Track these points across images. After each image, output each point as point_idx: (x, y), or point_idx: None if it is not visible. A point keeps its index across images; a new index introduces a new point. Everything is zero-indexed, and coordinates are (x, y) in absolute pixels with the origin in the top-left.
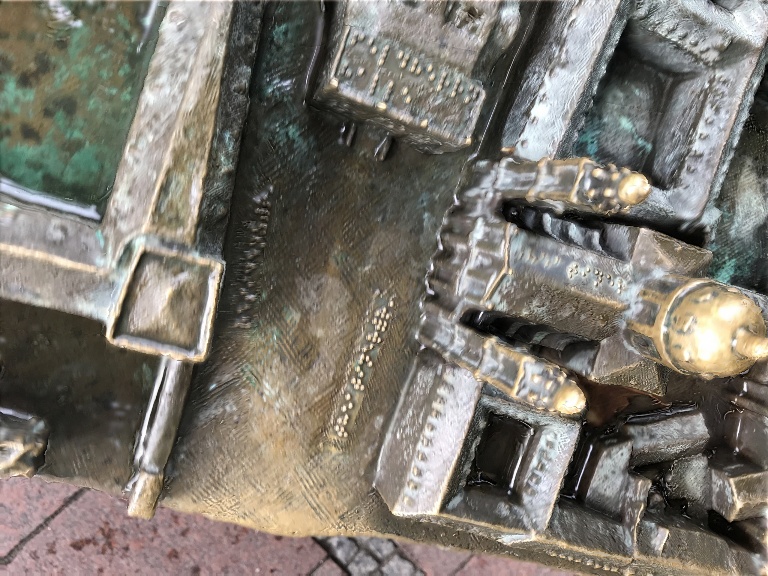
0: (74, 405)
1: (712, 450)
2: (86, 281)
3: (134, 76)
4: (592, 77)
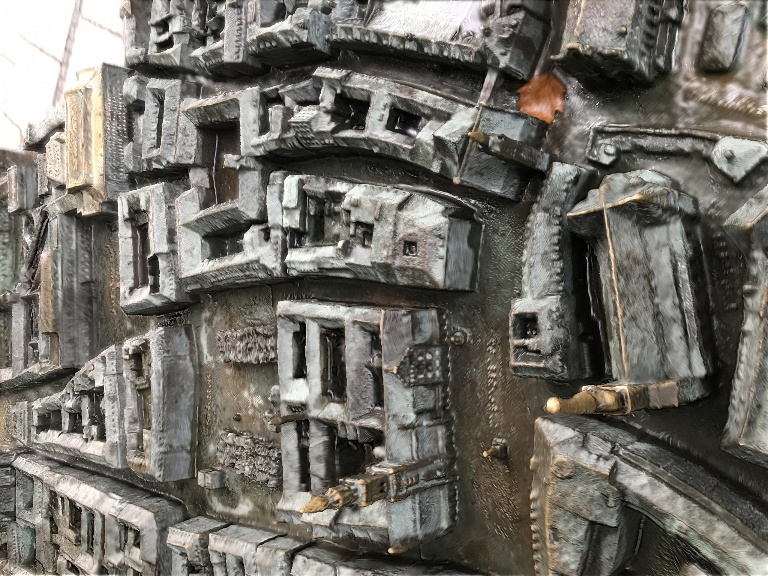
0: None
1: (5, 550)
2: None
3: None
4: None
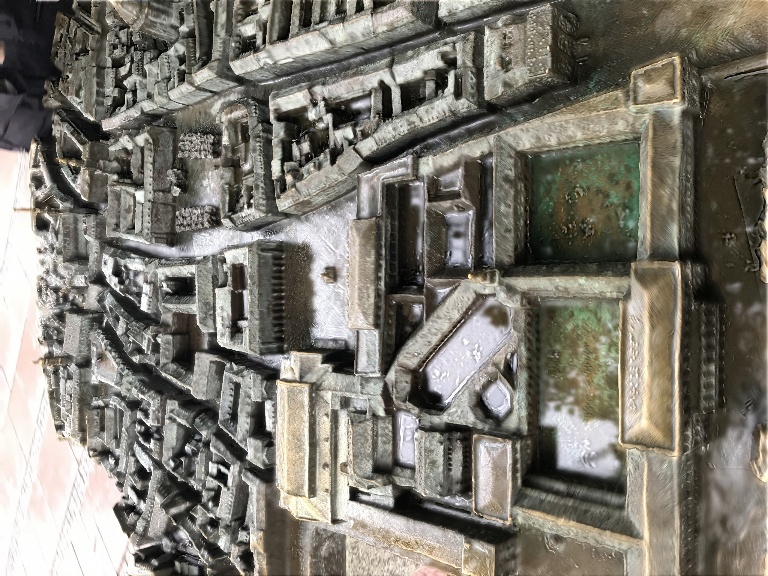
0: (767, 115)
1: None
2: (660, 123)
3: (590, 158)
4: None
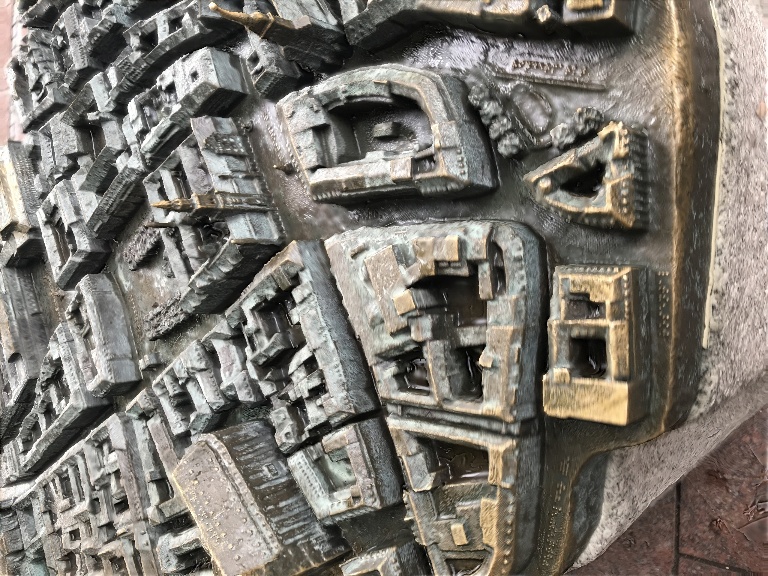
0: None
1: None
2: None
3: None
4: (20, 503)
